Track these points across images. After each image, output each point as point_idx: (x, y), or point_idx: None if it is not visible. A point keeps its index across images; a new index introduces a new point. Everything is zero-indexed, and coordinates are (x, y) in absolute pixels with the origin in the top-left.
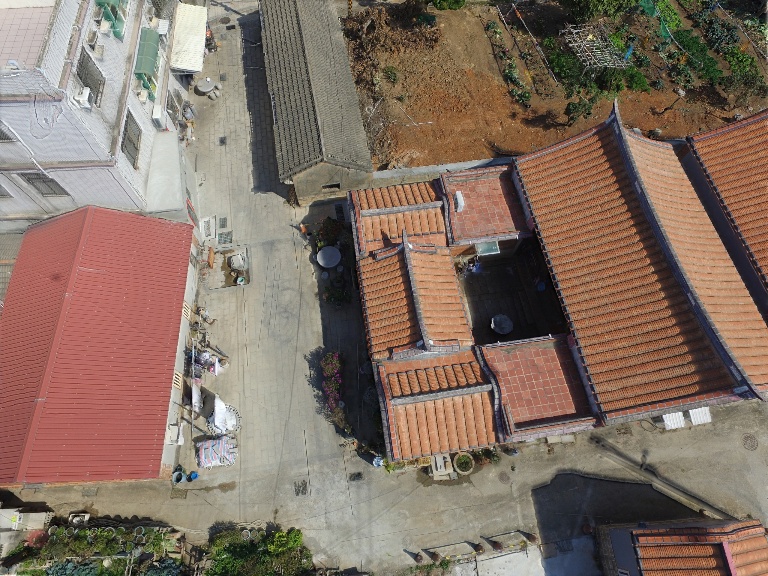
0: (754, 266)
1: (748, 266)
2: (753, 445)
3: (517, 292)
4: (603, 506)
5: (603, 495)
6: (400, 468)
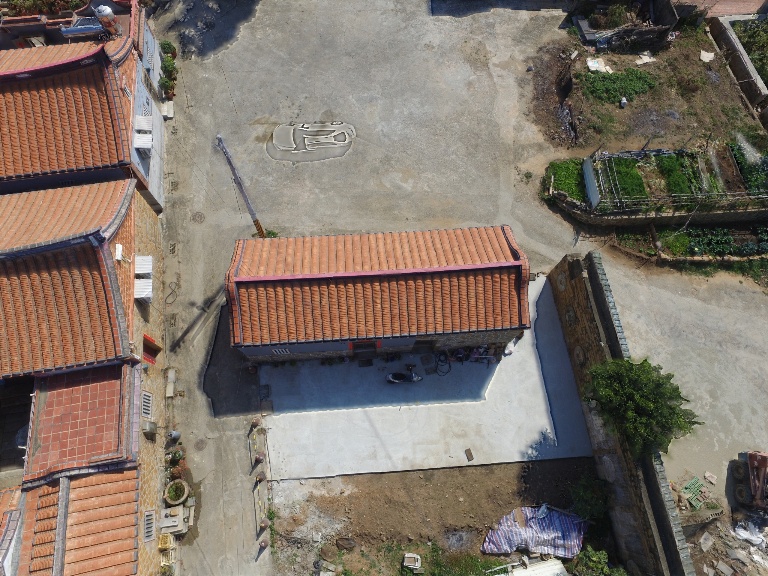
0: (4, 180)
1: (6, 184)
2: (200, 216)
3: (1, 409)
4: (235, 352)
5: (226, 350)
6: (171, 570)
